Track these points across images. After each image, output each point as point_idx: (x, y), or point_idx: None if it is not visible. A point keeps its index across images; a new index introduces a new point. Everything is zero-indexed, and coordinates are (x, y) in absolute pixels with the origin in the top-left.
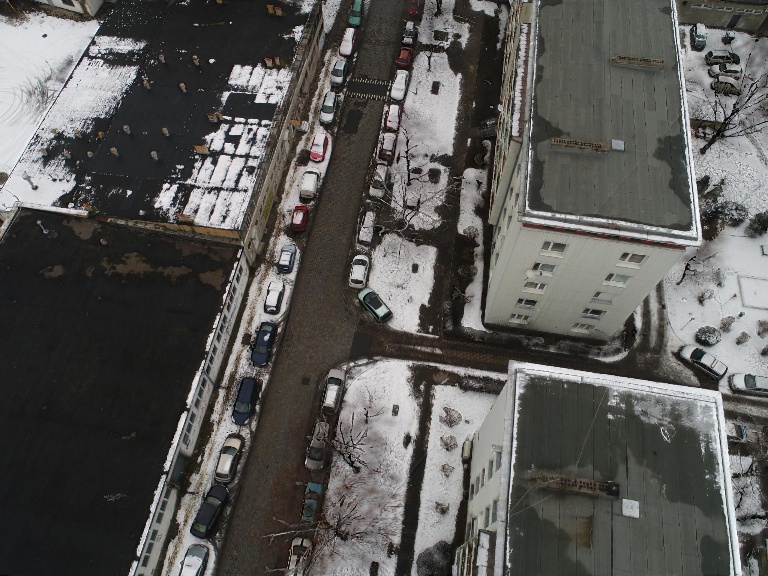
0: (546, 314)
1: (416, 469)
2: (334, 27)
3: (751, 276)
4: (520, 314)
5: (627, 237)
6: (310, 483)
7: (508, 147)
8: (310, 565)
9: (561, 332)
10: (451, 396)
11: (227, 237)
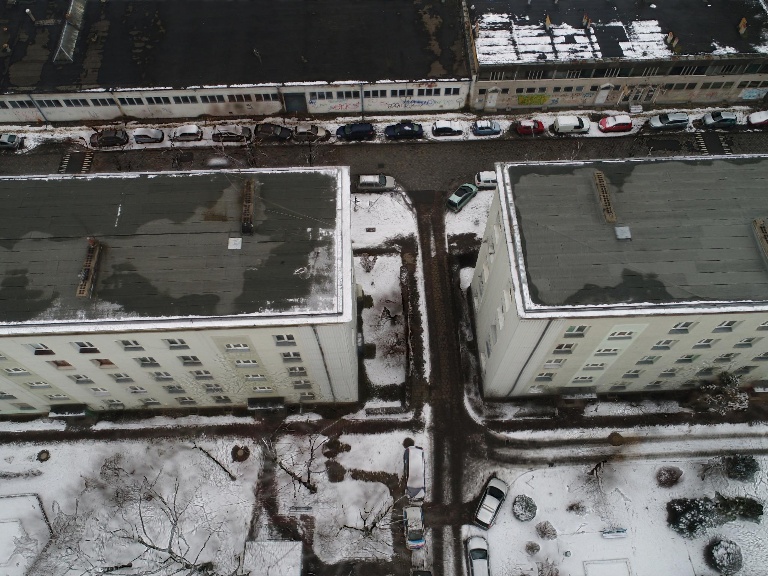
0: None
1: None
2: None
3: None
4: None
5: None
6: None
7: None
8: None
9: None
10: (393, 268)
11: (475, 65)
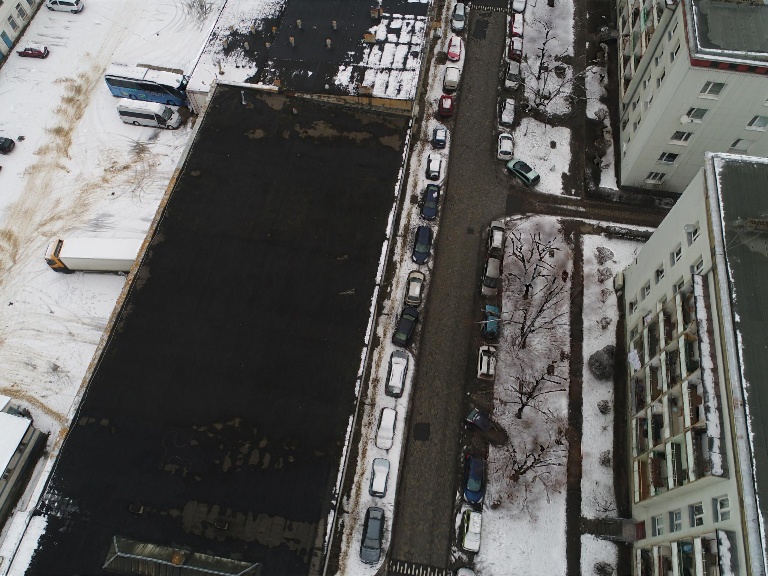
0: (682, 170)
1: (576, 297)
2: None
3: None
4: (658, 172)
5: None
6: (488, 305)
7: (657, 19)
8: (524, 337)
9: None
10: (598, 242)
11: (400, 109)
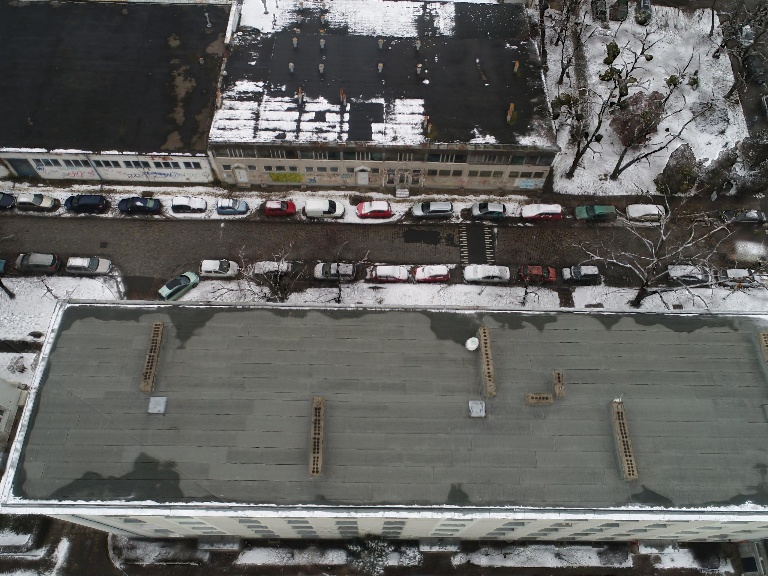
0: None
1: (7, 345)
2: (567, 196)
3: None
4: None
5: None
6: (4, 262)
7: None
8: None
9: None
10: None
11: None
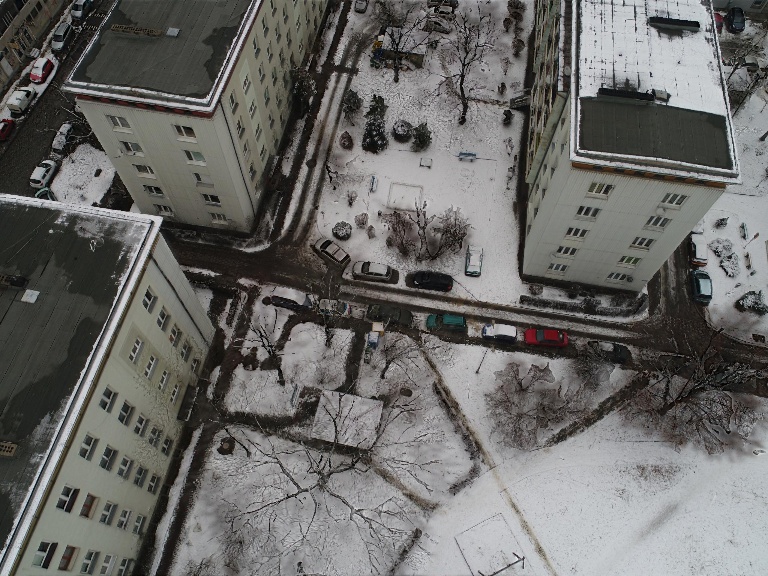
0: (178, 203)
1: None
2: None
3: (402, 183)
4: (160, 204)
5: (151, 104)
6: None
7: None
8: None
9: (207, 225)
10: None
11: None
